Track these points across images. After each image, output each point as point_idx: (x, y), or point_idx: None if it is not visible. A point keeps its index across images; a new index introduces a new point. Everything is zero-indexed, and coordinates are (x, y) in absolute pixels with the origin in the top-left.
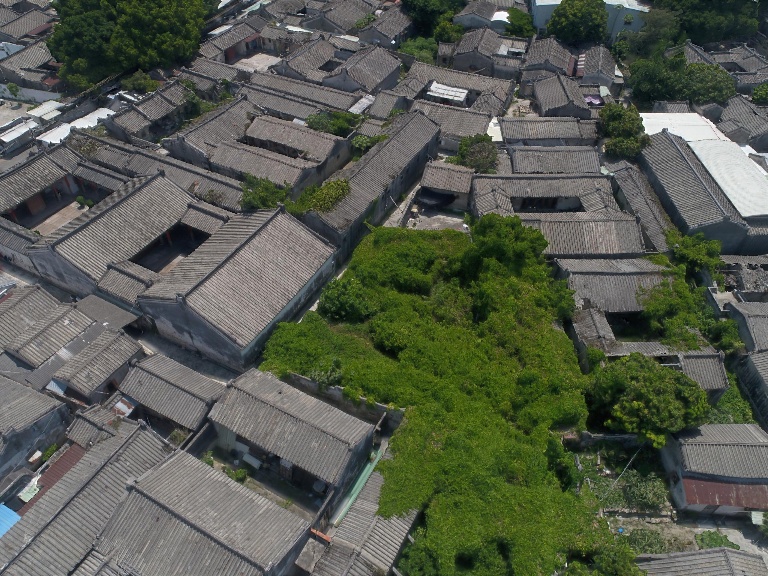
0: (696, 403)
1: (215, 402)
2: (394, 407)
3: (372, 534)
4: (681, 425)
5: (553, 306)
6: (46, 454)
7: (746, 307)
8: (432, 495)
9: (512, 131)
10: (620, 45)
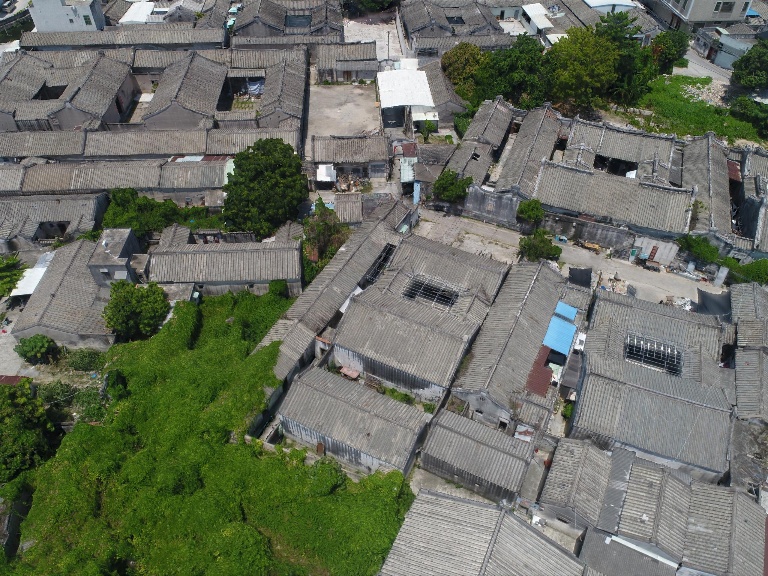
0: None
1: (430, 424)
2: (256, 440)
3: None
4: None
5: (13, 568)
6: (570, 407)
7: None
8: None
9: None
10: None
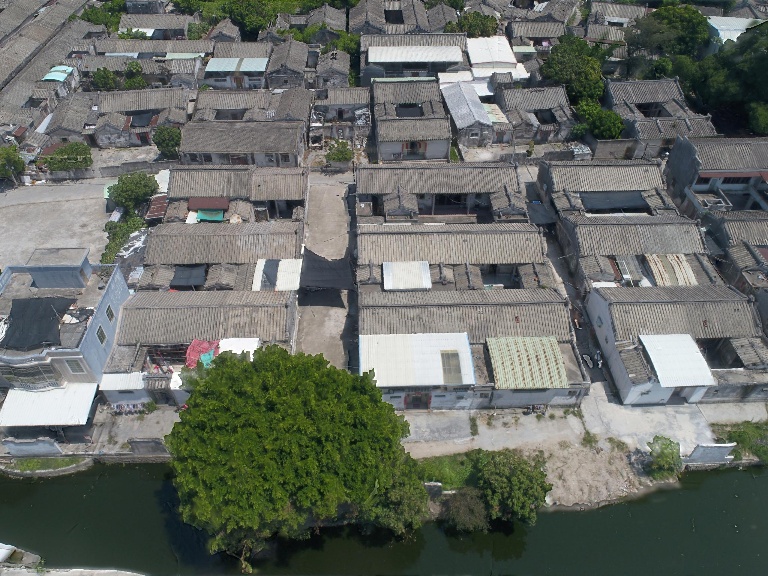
0: (234, 3)
1: None
2: None
3: None
4: (229, 6)
5: None
6: None
7: (301, 46)
8: None
9: (472, 10)
10: (661, 59)
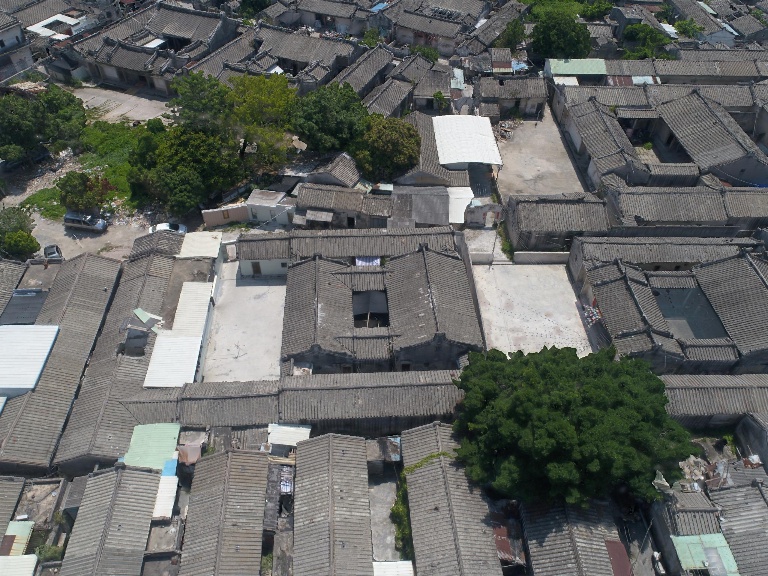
0: None
1: None
2: None
3: (516, 4)
4: None
5: None
6: None
7: None
8: (533, 5)
9: None
10: None
